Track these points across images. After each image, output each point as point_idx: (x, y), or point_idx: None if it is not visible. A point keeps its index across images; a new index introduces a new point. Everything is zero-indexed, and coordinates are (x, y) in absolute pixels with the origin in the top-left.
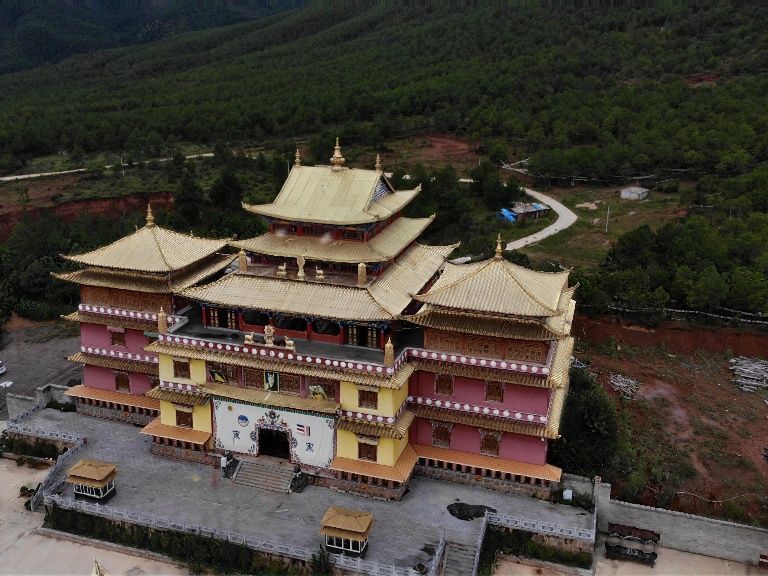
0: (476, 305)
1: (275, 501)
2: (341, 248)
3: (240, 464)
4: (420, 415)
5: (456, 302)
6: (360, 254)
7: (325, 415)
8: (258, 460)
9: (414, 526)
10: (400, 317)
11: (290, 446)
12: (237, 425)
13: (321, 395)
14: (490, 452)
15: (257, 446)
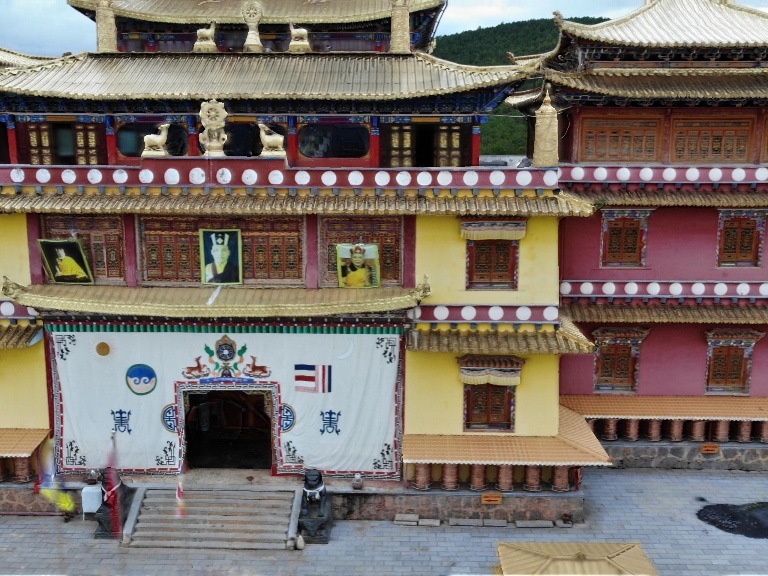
0: (699, 38)
1: (269, 574)
2: (329, 5)
3: (140, 496)
4: (578, 317)
5: (650, 38)
6: (378, 7)
7: (374, 326)
8: (187, 480)
9: (676, 572)
10: (540, 68)
11: (274, 429)
12: (124, 394)
13: (366, 270)
14: (726, 387)
15: (181, 444)
